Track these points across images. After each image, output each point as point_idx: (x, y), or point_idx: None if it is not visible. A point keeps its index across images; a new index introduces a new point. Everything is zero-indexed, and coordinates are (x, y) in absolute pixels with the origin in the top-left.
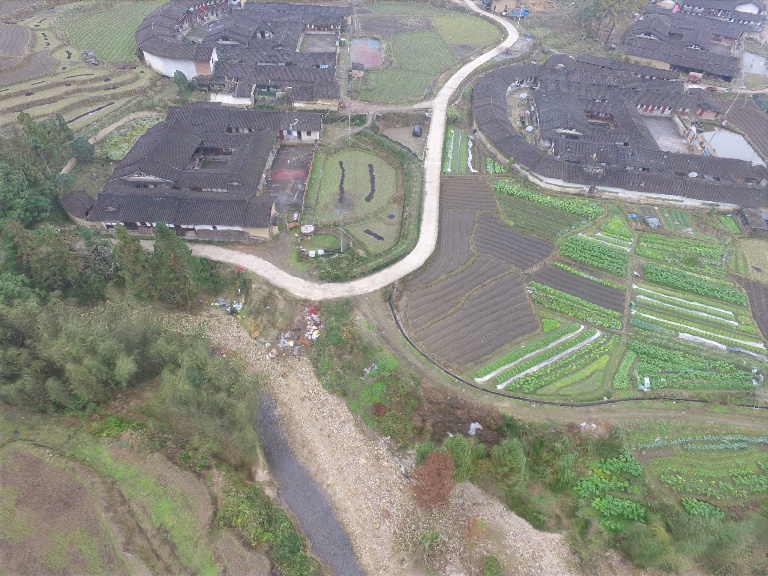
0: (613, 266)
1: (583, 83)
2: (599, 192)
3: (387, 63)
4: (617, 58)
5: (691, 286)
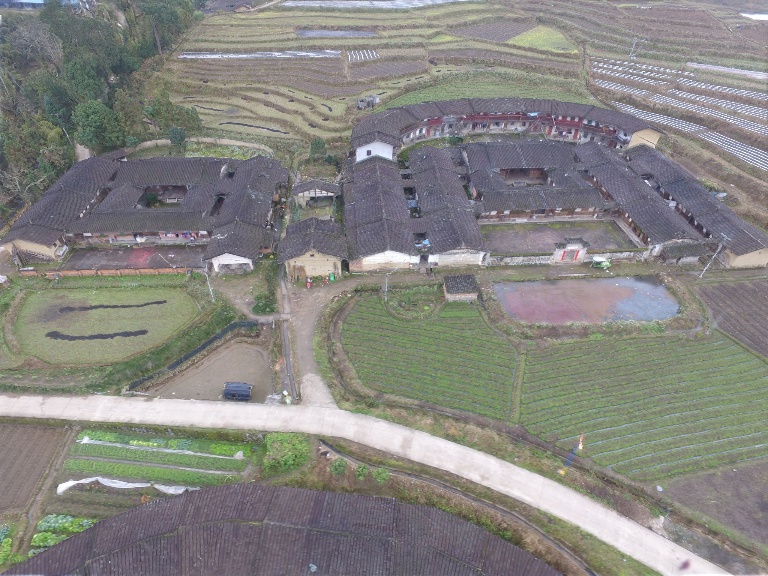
0: None
1: None
2: None
3: (526, 330)
4: None
5: None
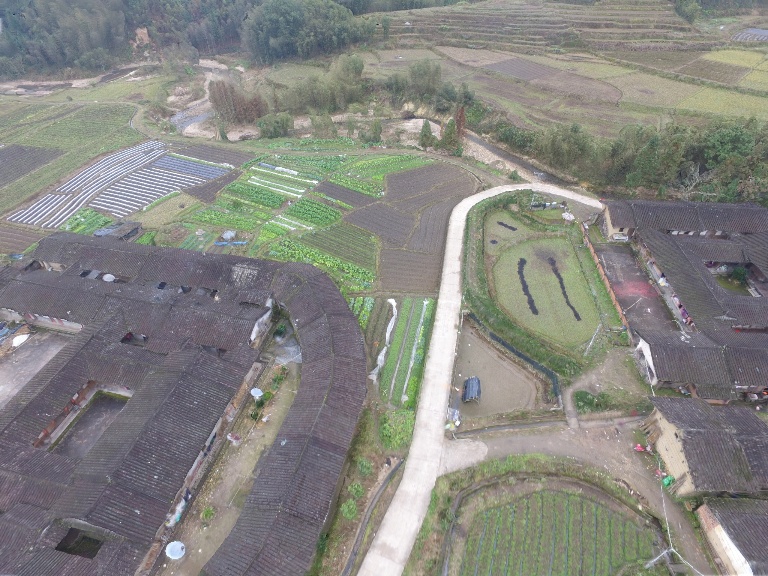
0: (308, 201)
1: None
2: None
3: None
4: None
5: (260, 190)
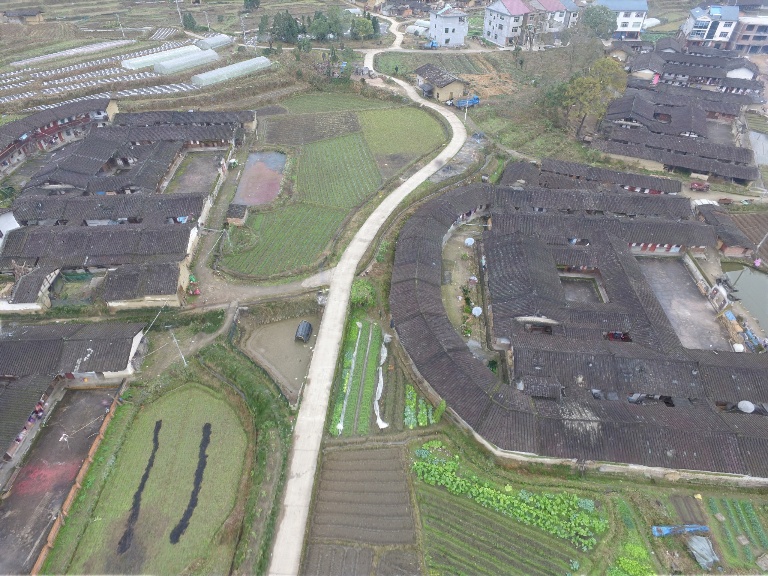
0: None
1: (552, 216)
2: (595, 463)
3: (284, 196)
4: (594, 157)
5: None
